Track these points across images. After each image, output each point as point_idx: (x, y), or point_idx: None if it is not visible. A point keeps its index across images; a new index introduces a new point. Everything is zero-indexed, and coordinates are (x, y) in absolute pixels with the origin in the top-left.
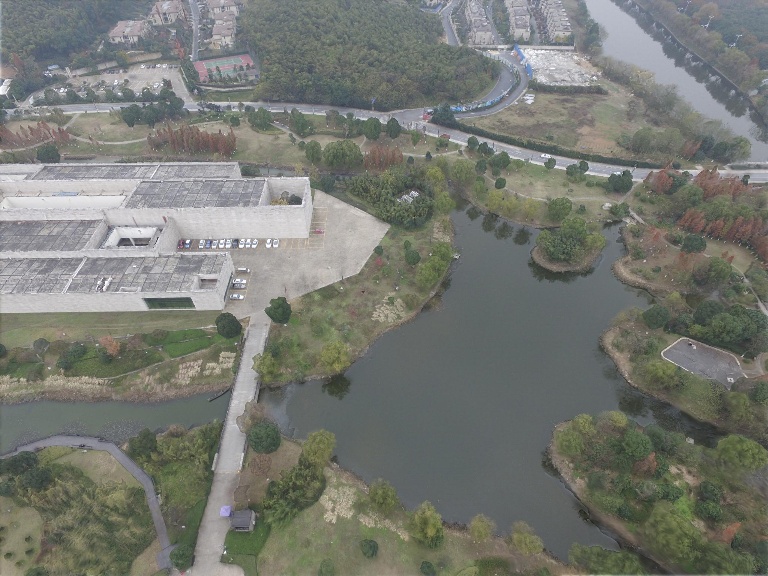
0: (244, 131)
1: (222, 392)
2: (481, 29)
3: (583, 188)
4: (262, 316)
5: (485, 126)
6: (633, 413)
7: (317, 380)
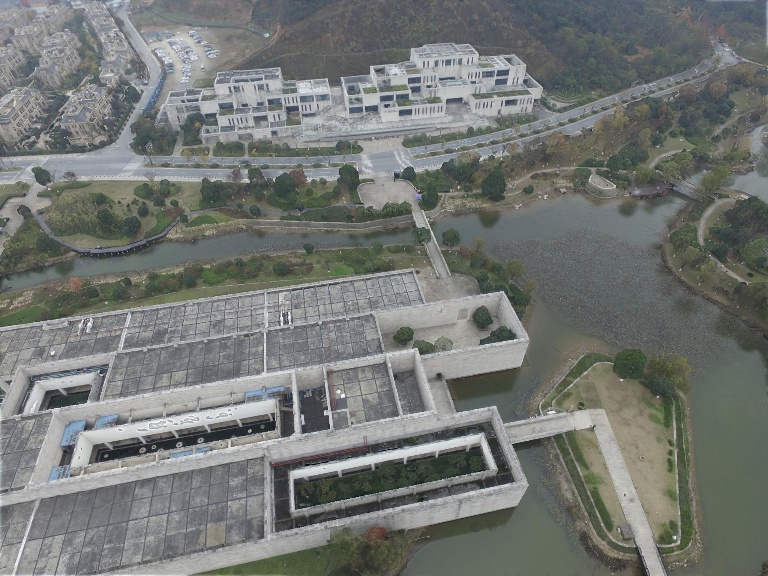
0: None
1: None
2: None
3: None
4: None
5: None
6: None
7: None
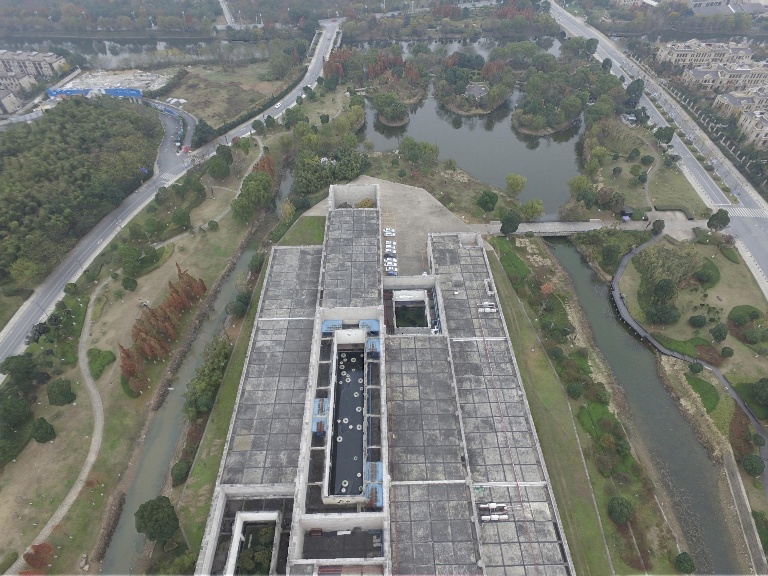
0: (147, 282)
1: (548, 242)
2: (2, 95)
3: (326, 98)
4: (478, 229)
5: (219, 123)
6: (493, 126)
7: (522, 204)
